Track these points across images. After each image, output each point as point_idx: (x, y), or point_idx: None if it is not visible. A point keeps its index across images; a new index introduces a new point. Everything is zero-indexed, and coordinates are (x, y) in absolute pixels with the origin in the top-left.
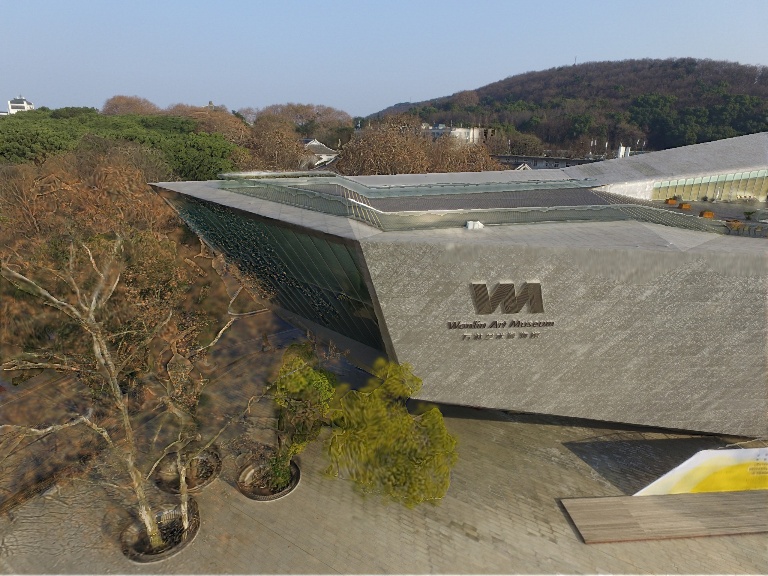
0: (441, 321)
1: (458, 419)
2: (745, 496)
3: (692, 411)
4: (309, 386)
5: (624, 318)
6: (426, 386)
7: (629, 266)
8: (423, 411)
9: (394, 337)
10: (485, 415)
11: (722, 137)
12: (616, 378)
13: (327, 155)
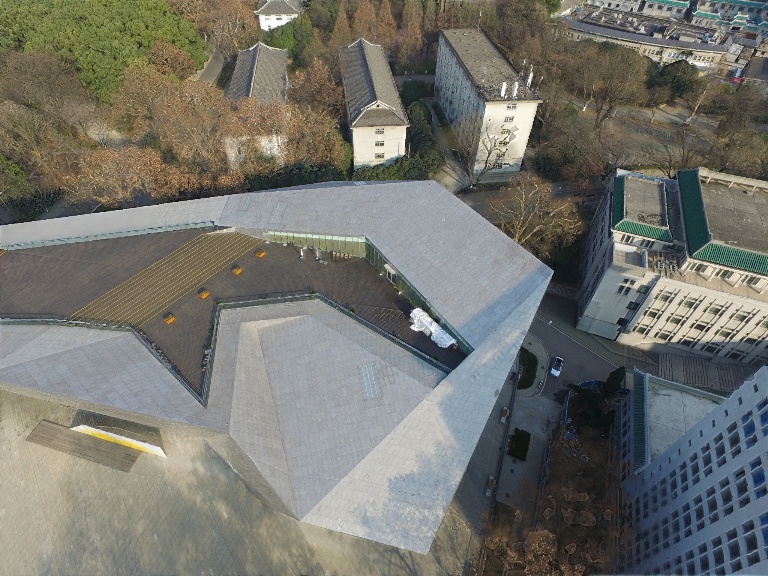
0: None
1: None
2: (109, 444)
3: None
4: None
5: None
6: None
7: None
8: None
9: None
10: None
11: None
12: None
13: (287, 15)
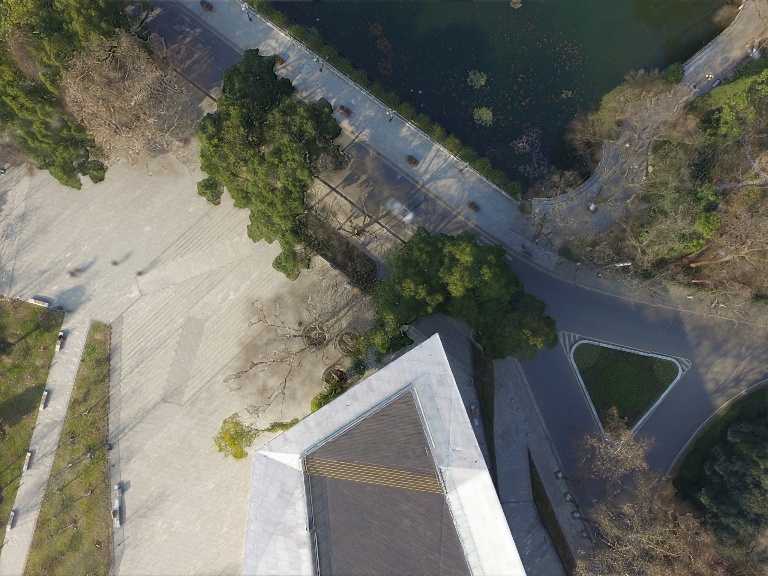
0: None
1: None
2: None
3: None
4: None
5: None
6: None
7: None
8: None
9: None
10: None
11: None
12: None
13: None
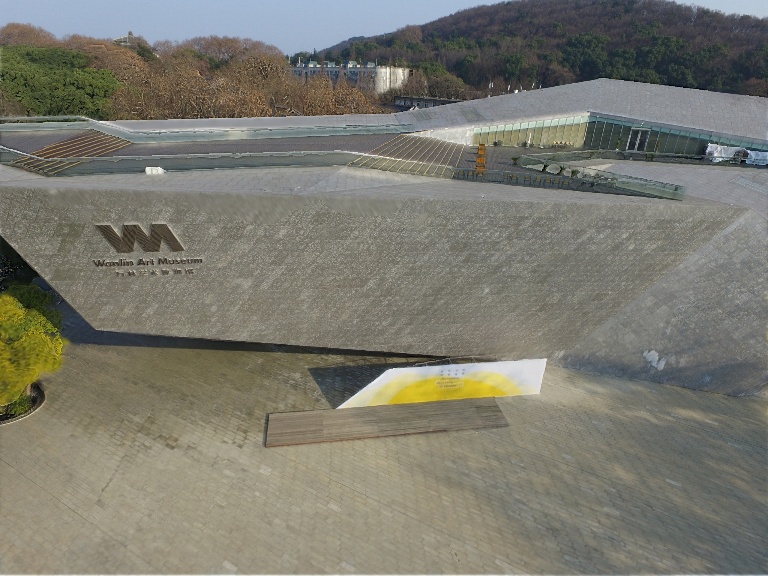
0: (85, 259)
1: (227, 351)
2: (433, 405)
3: (389, 336)
4: (7, 322)
5: (272, 255)
6: (105, 319)
7: (250, 208)
8: (198, 345)
9: (44, 275)
10: (254, 347)
11: (644, 80)
12: (296, 308)
13: None
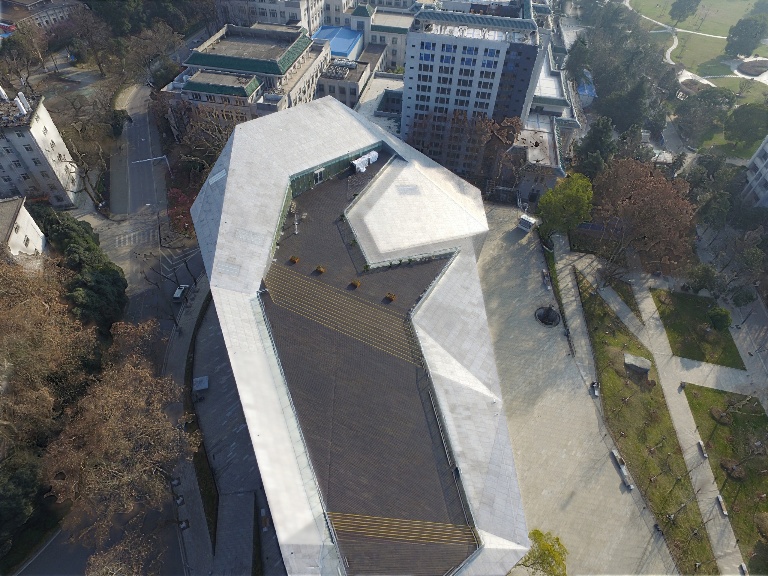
0: None
1: None
2: None
3: None
4: None
5: None
6: None
7: None
8: None
9: None
10: None
11: None
12: None
13: None
